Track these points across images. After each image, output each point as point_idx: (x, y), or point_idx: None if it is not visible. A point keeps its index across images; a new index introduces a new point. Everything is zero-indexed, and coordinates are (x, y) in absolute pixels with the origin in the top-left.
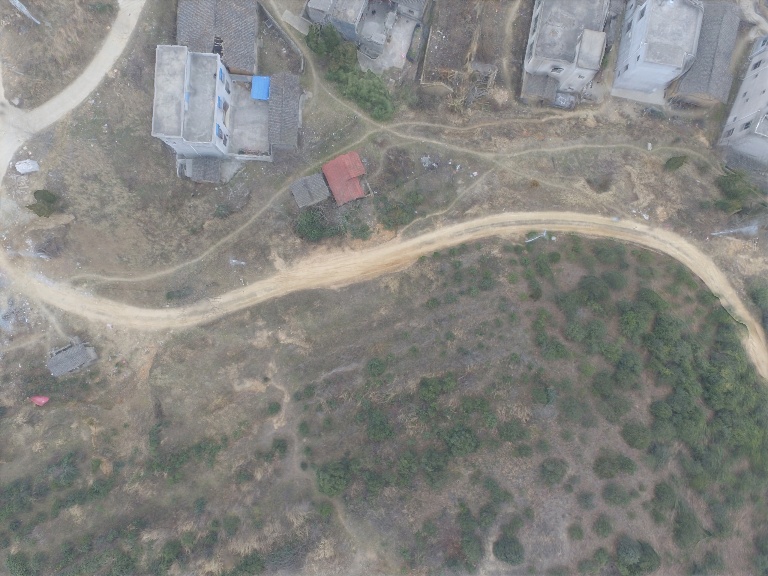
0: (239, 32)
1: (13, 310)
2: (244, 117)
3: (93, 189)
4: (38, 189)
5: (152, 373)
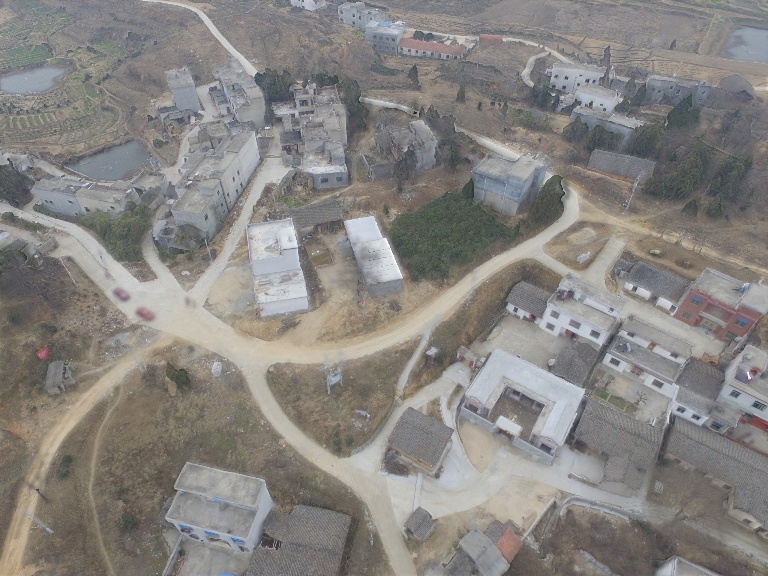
0: (287, 570)
1: (119, 346)
2: (219, 563)
3: (192, 413)
4: (199, 374)
5: (2, 432)
